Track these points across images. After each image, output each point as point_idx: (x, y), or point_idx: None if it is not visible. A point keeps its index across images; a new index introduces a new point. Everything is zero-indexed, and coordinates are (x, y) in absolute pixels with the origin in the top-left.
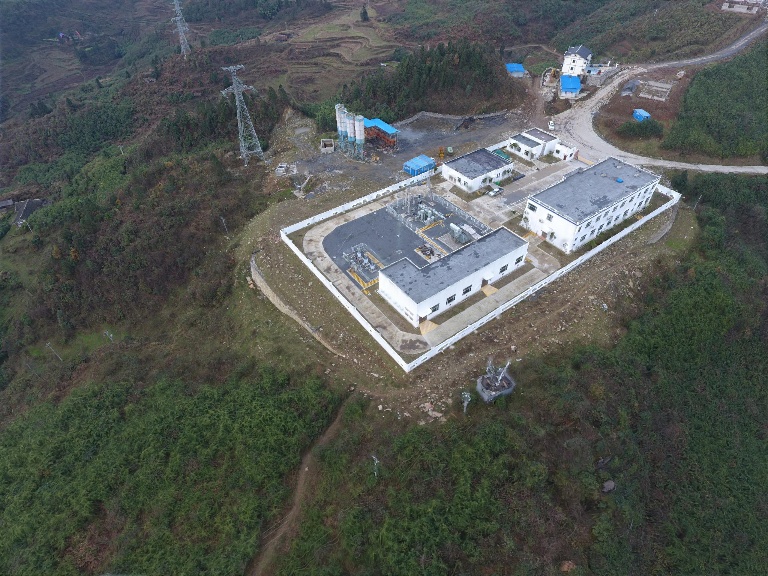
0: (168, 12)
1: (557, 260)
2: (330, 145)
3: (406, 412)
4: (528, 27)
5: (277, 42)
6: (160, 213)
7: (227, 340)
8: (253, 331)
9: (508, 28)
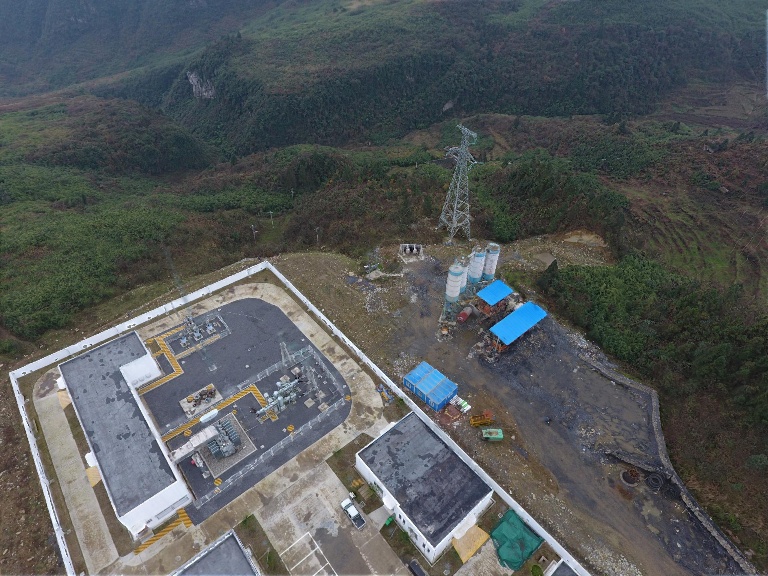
0: None
1: None
2: None
3: None
4: None
5: None
6: None
7: None
8: None
9: None
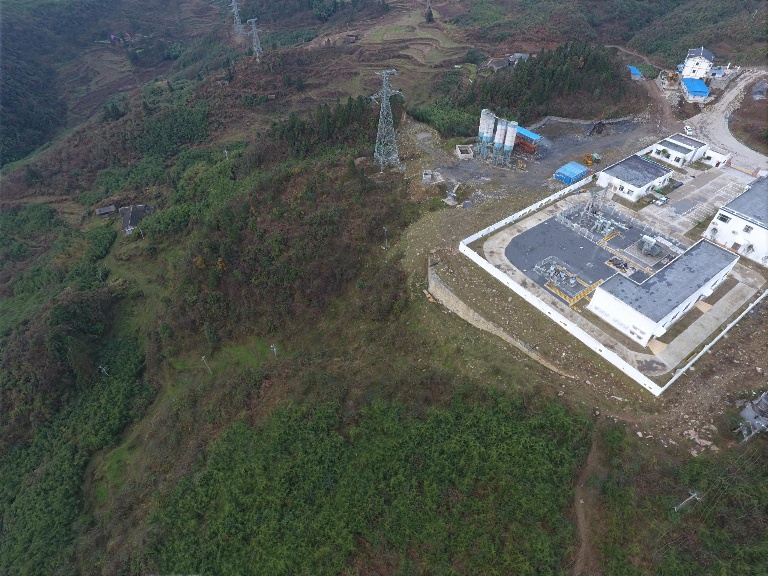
0: (222, 14)
1: (759, 274)
2: (465, 151)
3: (671, 440)
4: (603, 28)
5: (345, 44)
6: (310, 222)
7: (422, 357)
8: (456, 349)
9: (584, 29)
